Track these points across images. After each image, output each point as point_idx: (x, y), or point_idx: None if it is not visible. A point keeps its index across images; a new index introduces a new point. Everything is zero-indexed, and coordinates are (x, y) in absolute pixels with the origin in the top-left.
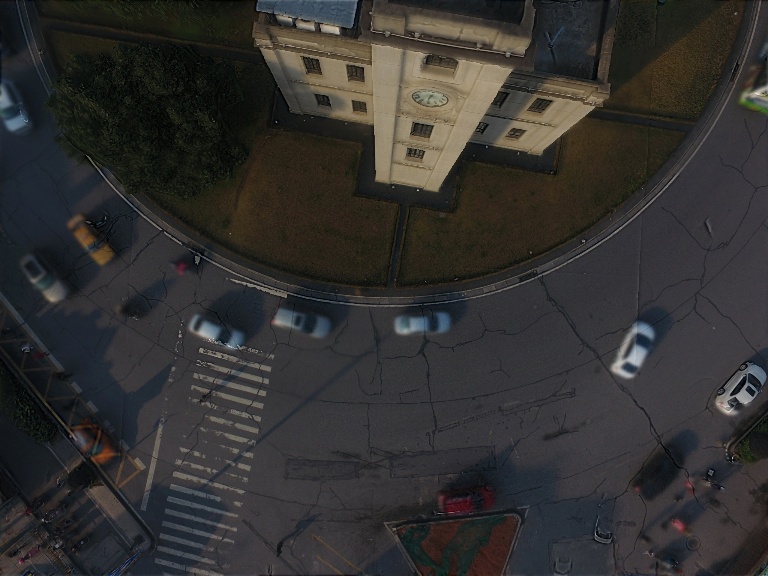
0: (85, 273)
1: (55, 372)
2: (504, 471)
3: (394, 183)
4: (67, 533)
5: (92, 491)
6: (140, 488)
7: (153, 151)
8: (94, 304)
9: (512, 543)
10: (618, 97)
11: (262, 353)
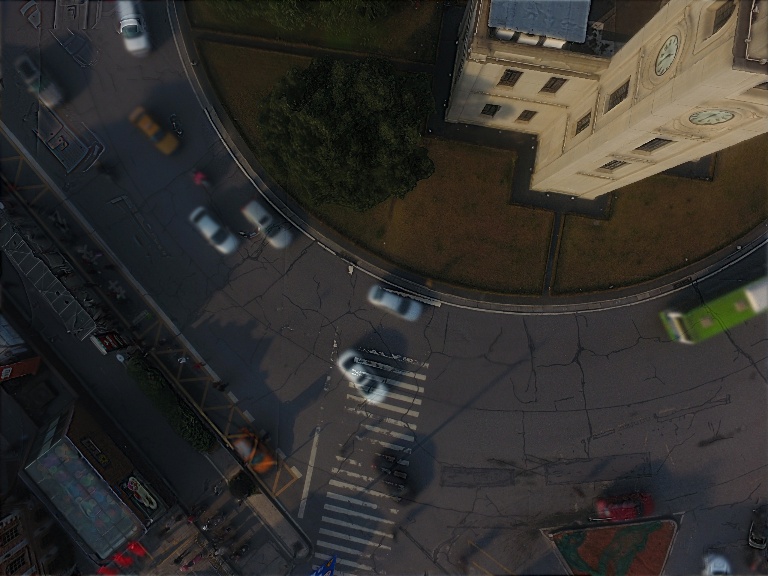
0: (239, 284)
1: (211, 382)
2: (659, 477)
3: (549, 191)
4: (225, 540)
5: (250, 499)
6: (297, 496)
7: (357, 166)
8: (249, 314)
9: (668, 549)
10: None
11: (417, 362)
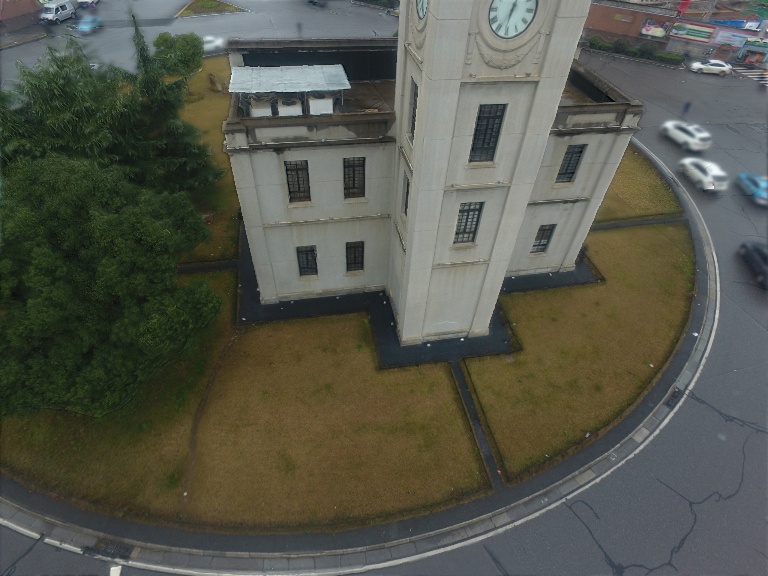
0: None
1: None
2: None
3: (427, 341)
4: None
5: None
6: None
7: (52, 294)
8: None
9: None
10: (603, 212)
11: None
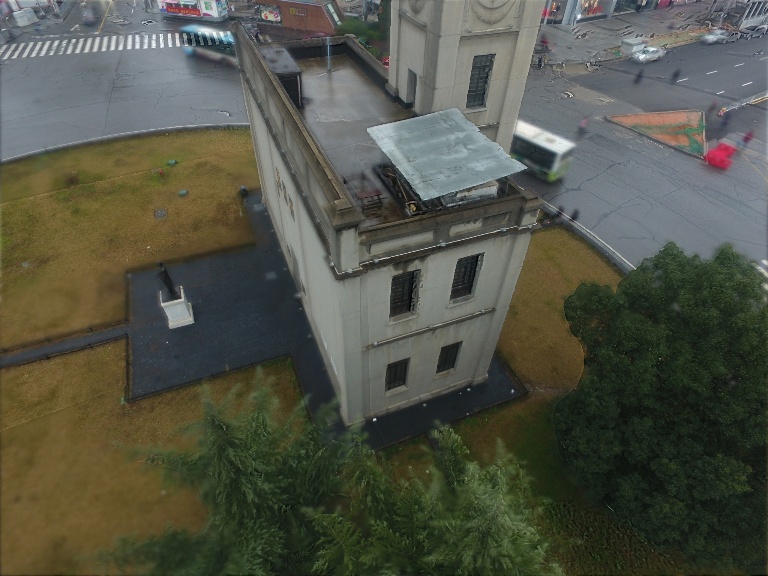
0: None
1: None
2: (593, 131)
3: None
4: None
5: None
6: None
7: None
8: None
9: (625, 115)
10: None
11: None
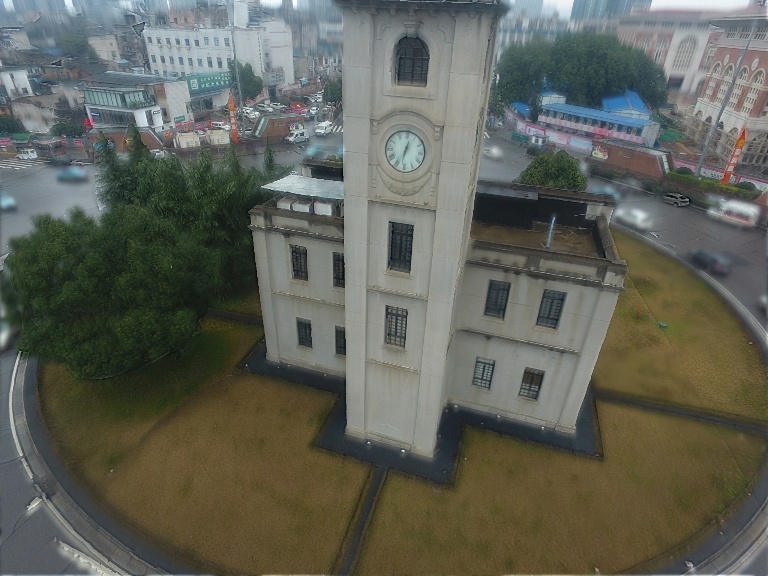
0: None
1: None
2: None
3: (371, 438)
4: None
5: None
6: None
7: (84, 283)
8: None
9: None
10: (655, 389)
11: None
